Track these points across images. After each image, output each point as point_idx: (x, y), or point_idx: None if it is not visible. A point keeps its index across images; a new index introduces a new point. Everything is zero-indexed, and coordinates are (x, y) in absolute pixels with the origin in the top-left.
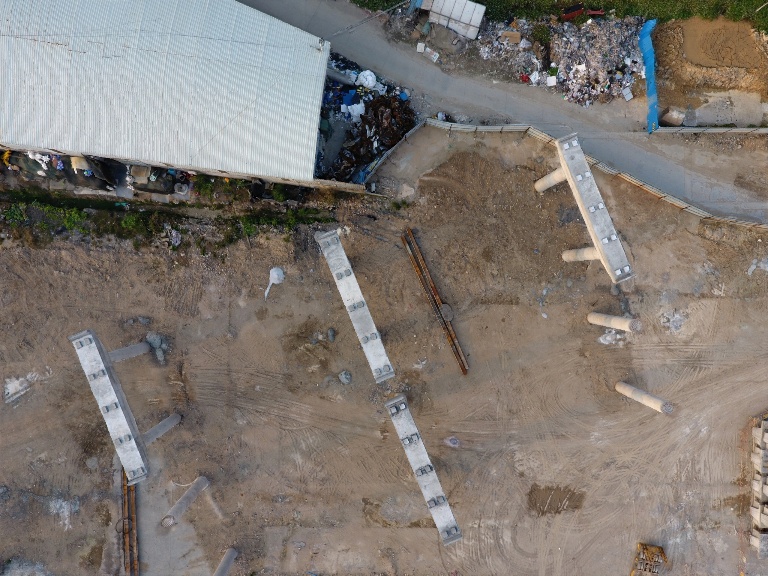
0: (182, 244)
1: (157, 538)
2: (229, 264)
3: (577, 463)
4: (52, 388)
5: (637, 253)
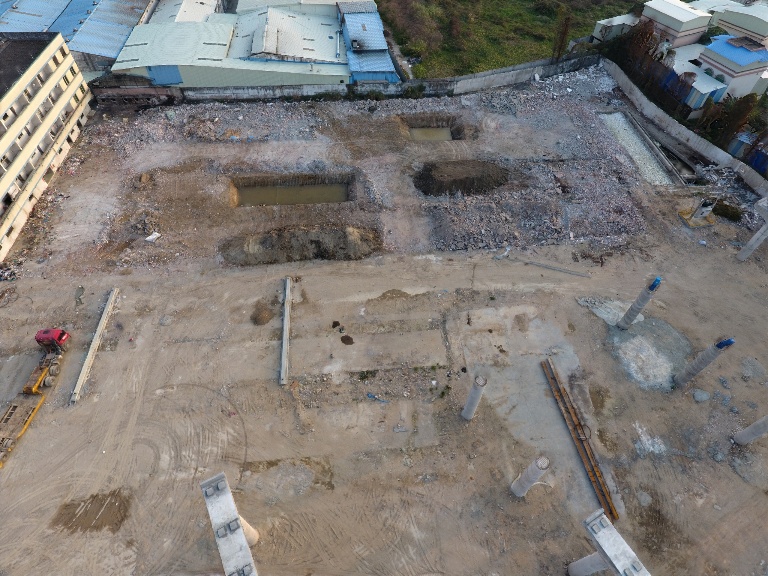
0: None
1: (546, 422)
2: None
3: (47, 571)
4: None
5: None
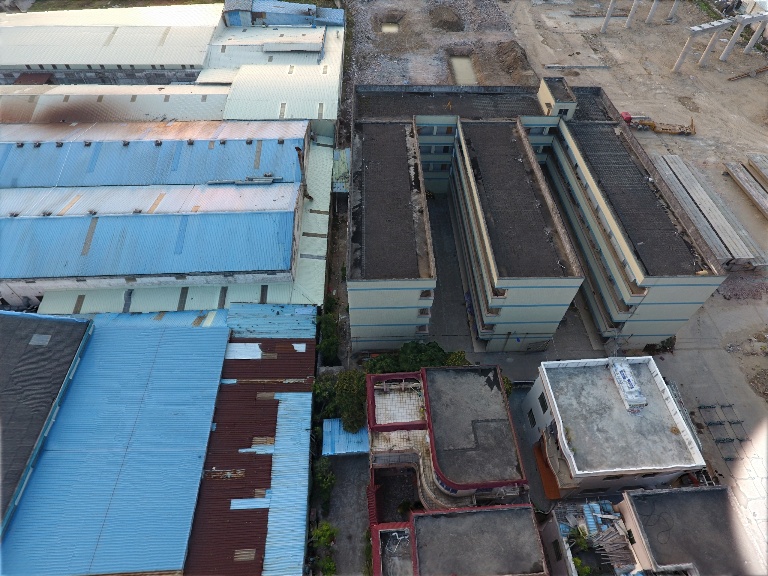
0: None
1: None
2: None
3: None
4: (640, 4)
5: None
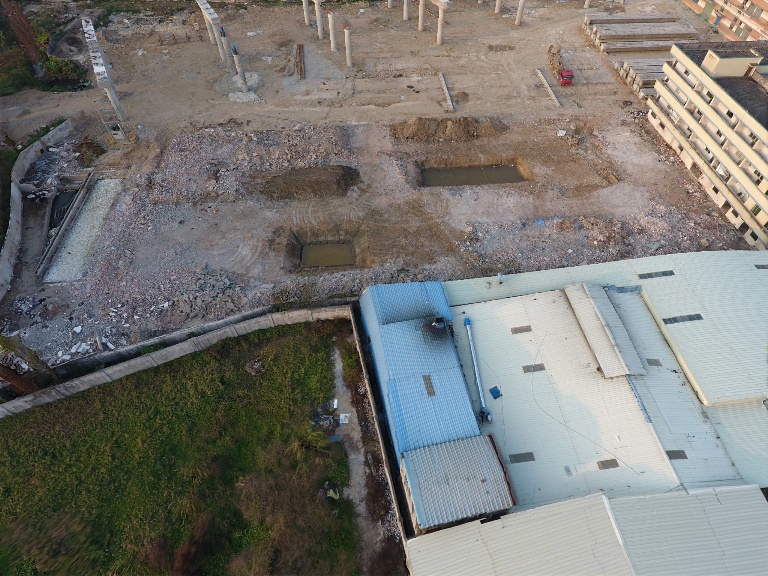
0: (324, 5)
1: None
2: (343, 8)
3: (507, 40)
4: None
5: (508, 1)
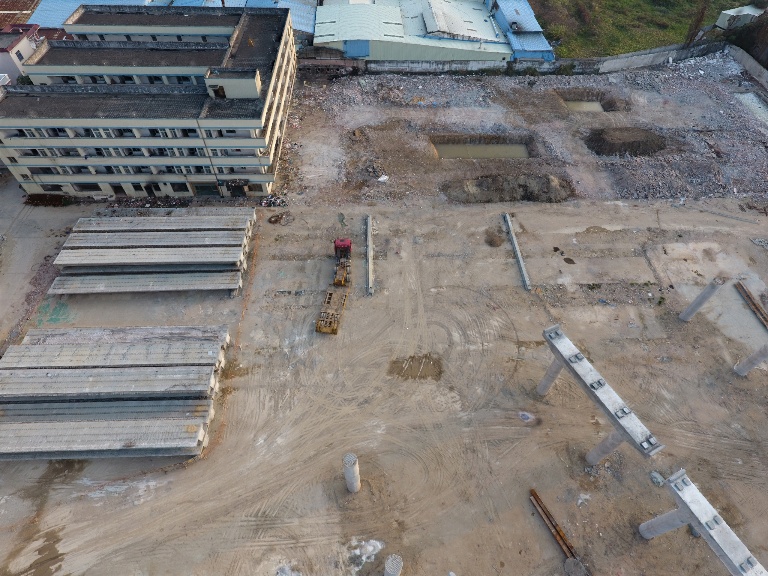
0: None
1: (749, 327)
2: None
3: (397, 402)
4: None
5: None
